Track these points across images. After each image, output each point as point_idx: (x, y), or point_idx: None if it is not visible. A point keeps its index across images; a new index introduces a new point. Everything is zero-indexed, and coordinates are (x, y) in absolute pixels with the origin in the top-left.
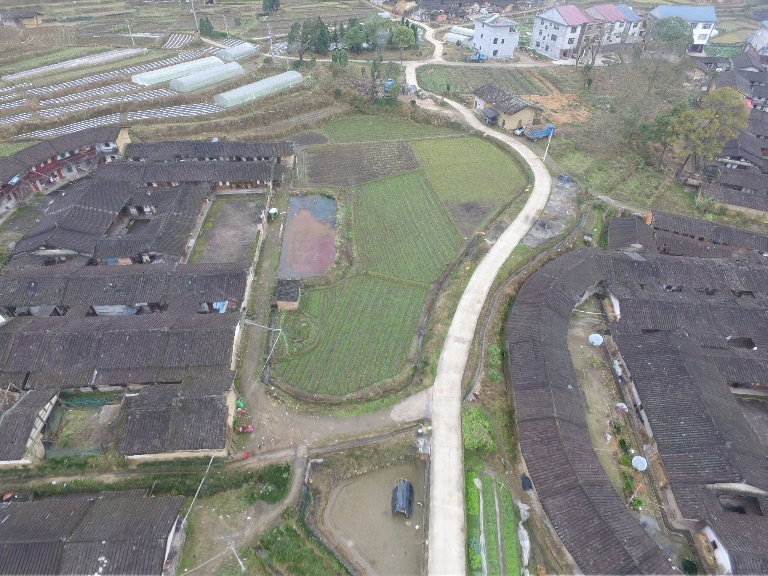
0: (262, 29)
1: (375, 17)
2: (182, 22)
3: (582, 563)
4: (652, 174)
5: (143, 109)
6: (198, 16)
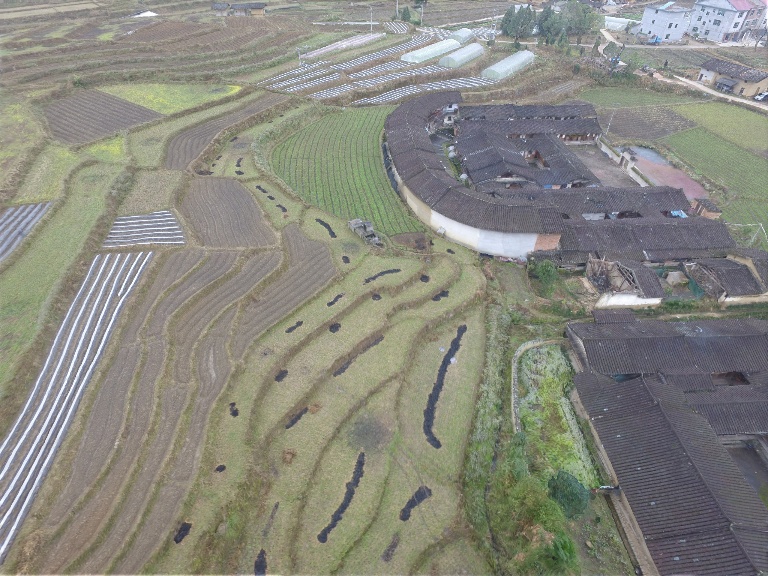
0: (428, 19)
1: (580, 4)
2: (353, 14)
3: None
4: None
5: (429, 82)
6: (359, 9)
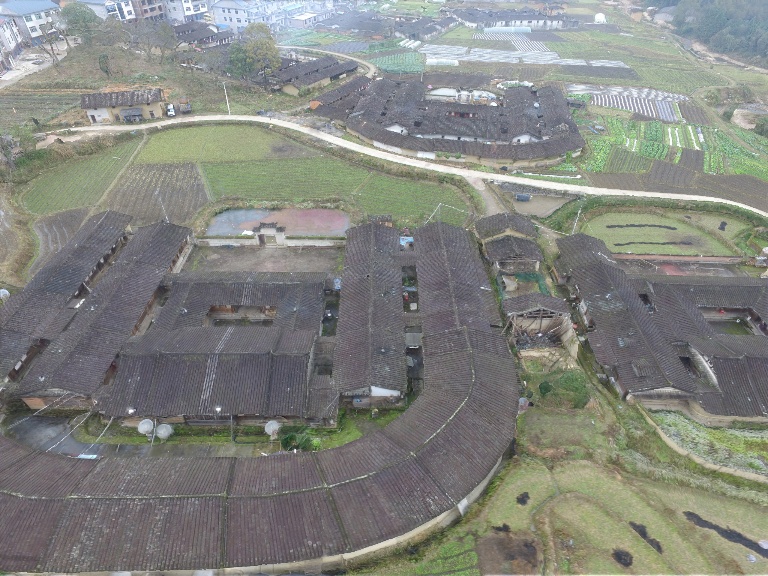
0: None
1: None
2: None
3: (541, 155)
4: (258, 95)
5: None
6: None
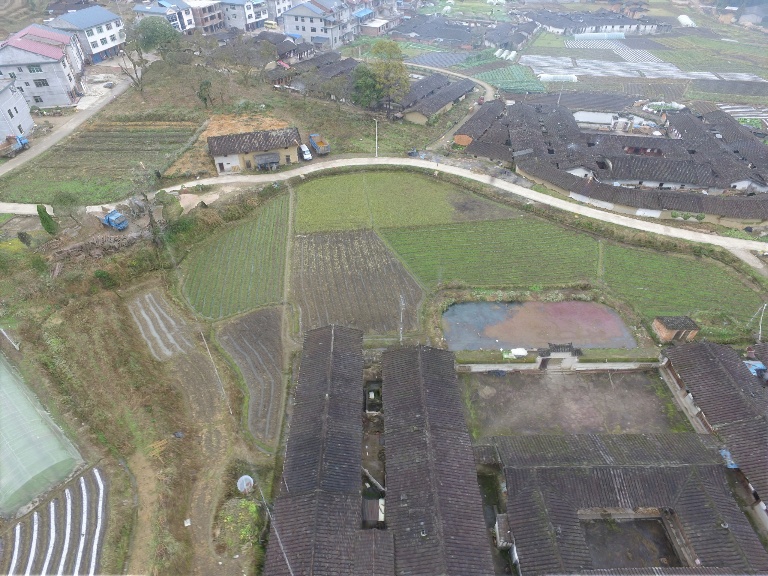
0: None
1: None
2: None
3: None
4: (383, 125)
5: None
6: None
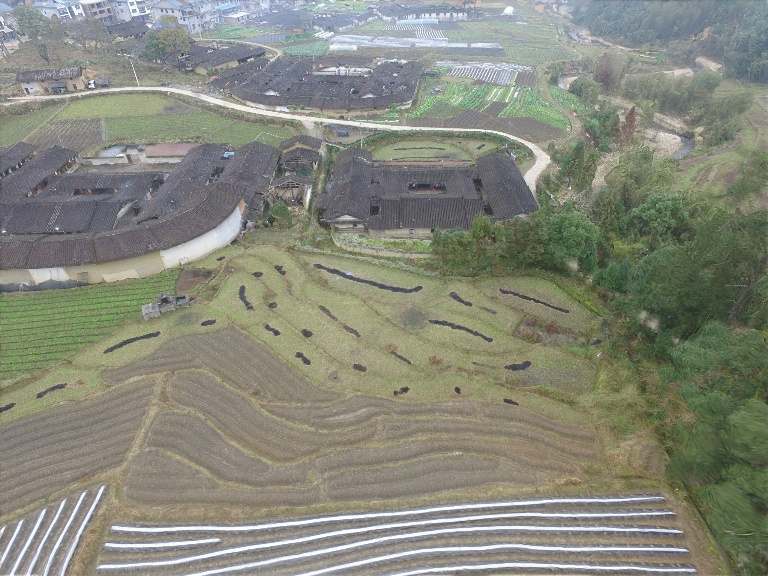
0: None
1: None
2: None
3: (369, 106)
4: (172, 75)
5: None
6: None
